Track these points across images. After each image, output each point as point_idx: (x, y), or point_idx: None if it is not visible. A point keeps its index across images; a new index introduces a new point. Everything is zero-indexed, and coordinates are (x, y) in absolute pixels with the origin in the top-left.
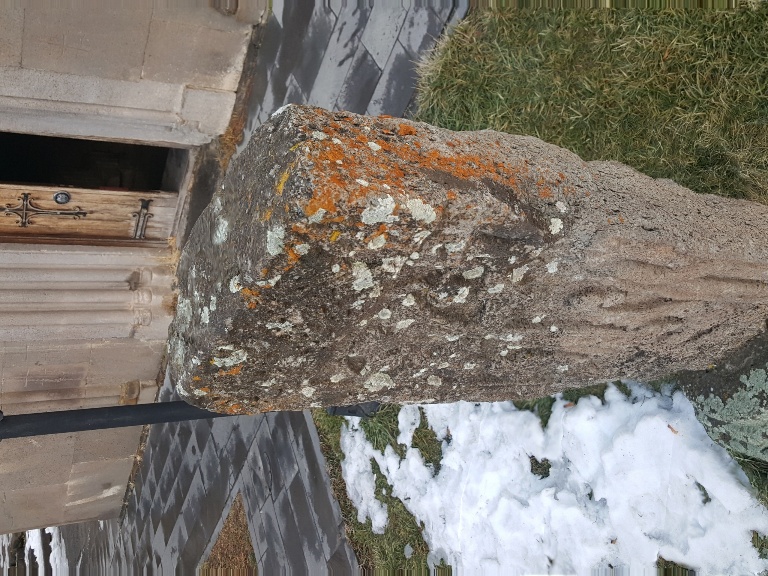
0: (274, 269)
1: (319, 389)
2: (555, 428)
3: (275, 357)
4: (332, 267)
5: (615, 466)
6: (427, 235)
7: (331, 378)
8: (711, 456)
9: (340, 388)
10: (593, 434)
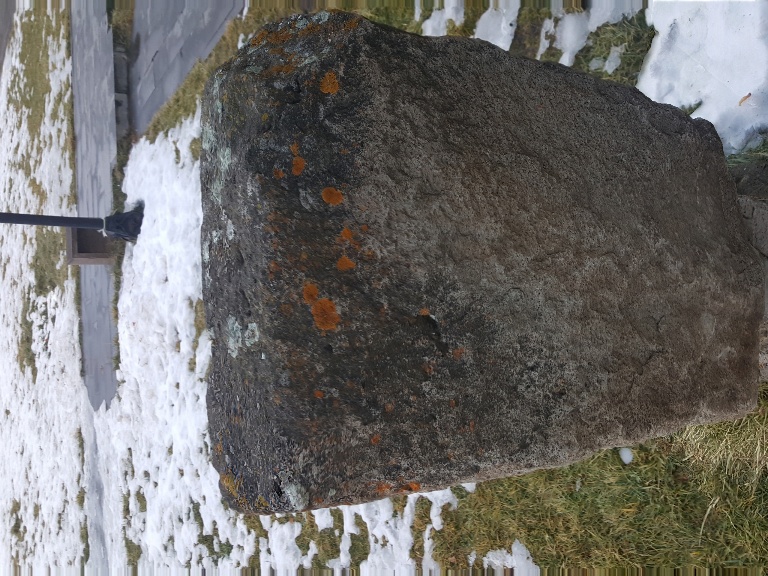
0: None
1: None
2: None
3: None
4: None
5: None
6: None
7: None
8: None
9: None
10: None
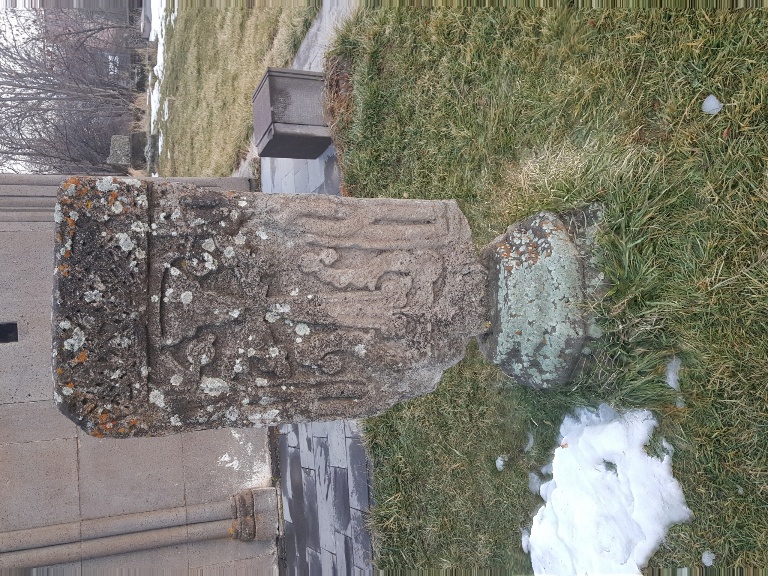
0: (66, 236)
1: (166, 394)
2: (538, 572)
3: (106, 337)
4: (102, 234)
5: (568, 531)
6: (146, 200)
7: (171, 382)
8: (587, 429)
9: (183, 392)
10: (549, 531)
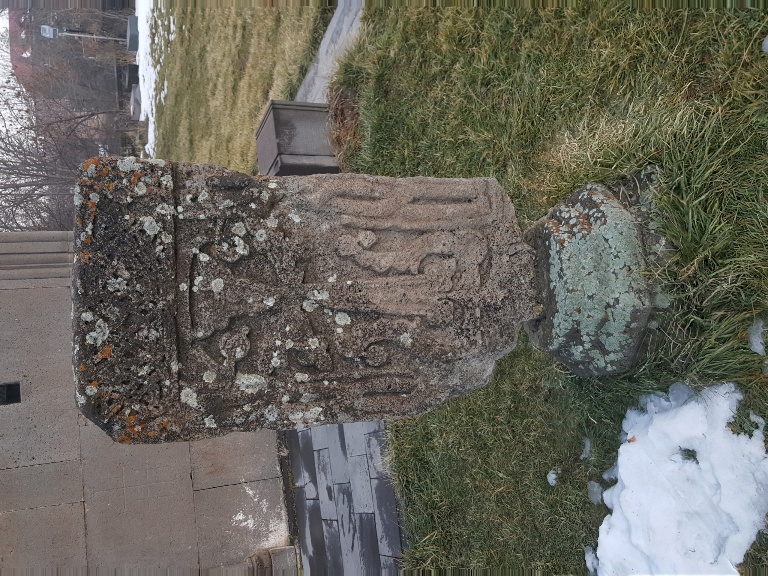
0: (86, 220)
1: (198, 392)
2: None
3: (131, 329)
4: (125, 218)
5: (644, 535)
6: (171, 181)
7: (204, 379)
8: (657, 416)
9: (217, 390)
10: (619, 540)
